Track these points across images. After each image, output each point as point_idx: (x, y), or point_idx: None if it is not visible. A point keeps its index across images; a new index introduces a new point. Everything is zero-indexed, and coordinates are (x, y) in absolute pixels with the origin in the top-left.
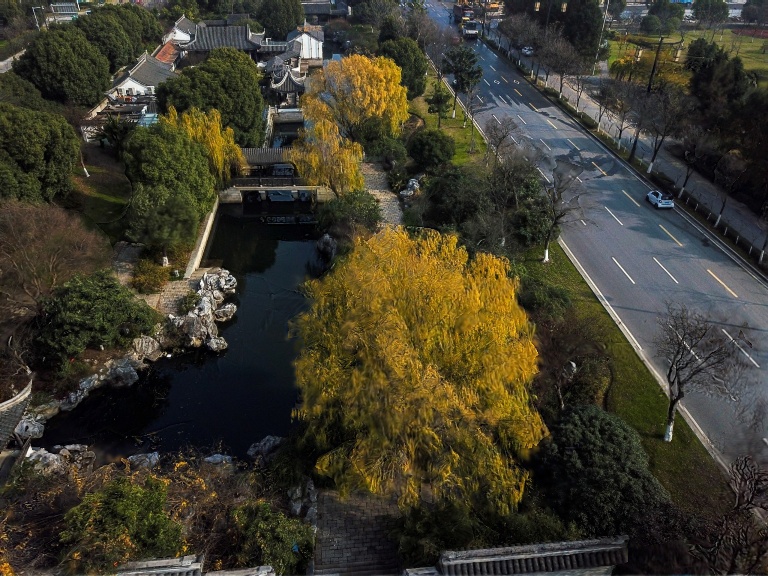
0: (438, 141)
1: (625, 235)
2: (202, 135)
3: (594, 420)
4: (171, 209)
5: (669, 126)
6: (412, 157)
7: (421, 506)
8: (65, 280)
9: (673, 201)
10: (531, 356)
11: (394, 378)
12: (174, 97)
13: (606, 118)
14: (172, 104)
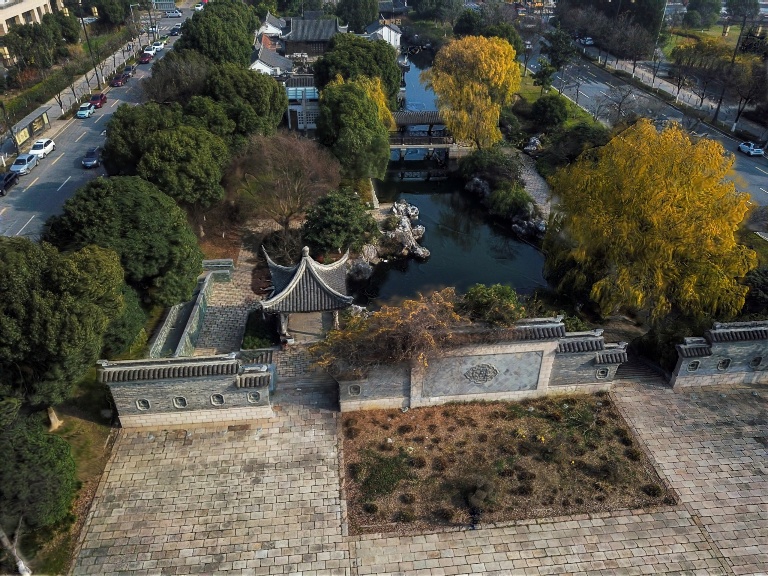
0: (558, 104)
1: (731, 174)
2: (370, 96)
3: (767, 273)
4: (376, 148)
5: (753, 90)
6: (534, 118)
7: (666, 318)
8: (325, 192)
9: (763, 150)
10: (744, 210)
11: (646, 227)
12: (336, 68)
13: (685, 90)
14: (336, 73)
